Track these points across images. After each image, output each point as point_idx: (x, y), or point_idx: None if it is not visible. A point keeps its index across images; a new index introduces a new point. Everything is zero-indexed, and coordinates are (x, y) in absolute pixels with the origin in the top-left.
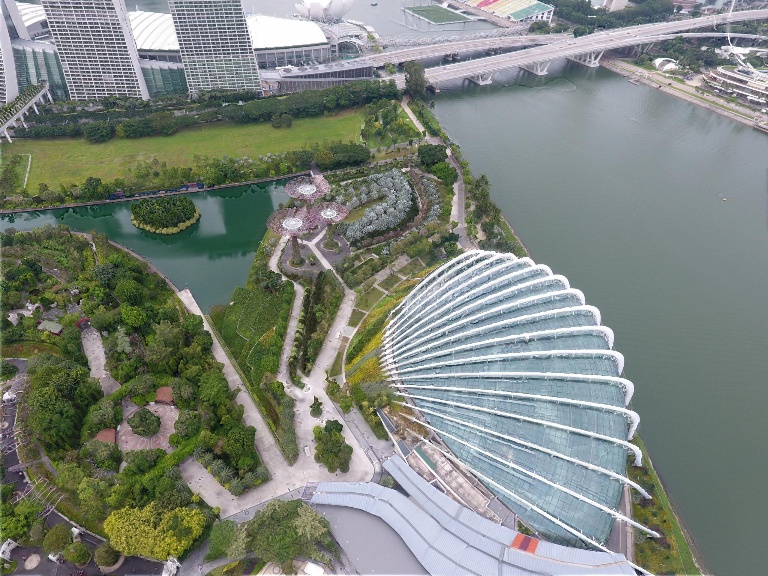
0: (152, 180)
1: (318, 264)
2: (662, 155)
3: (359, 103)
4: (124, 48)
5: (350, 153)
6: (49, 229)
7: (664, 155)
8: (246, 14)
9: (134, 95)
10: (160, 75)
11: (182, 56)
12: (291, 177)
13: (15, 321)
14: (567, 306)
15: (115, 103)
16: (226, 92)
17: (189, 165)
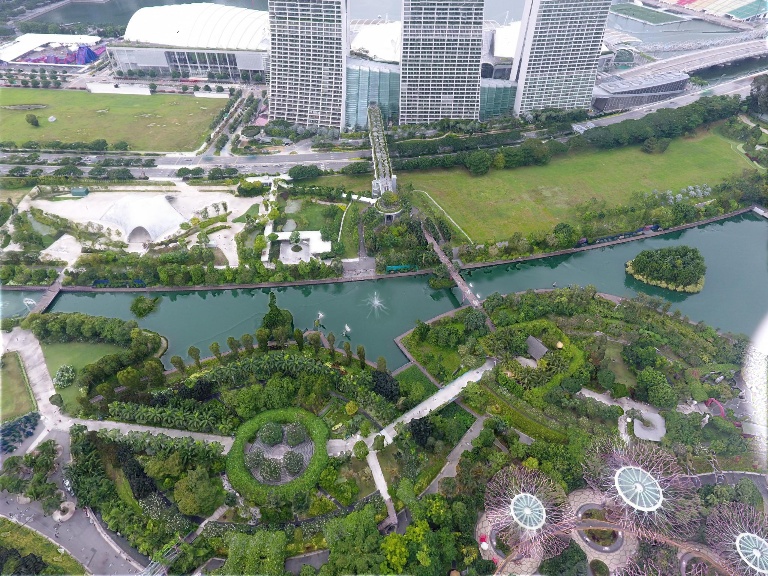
0: (617, 224)
1: None
2: None
3: (708, 122)
4: (476, 66)
5: None
6: (579, 291)
7: None
8: (488, 20)
9: (470, 117)
10: (494, 94)
11: (526, 73)
12: (736, 215)
13: None
14: None
15: (451, 127)
16: (561, 112)
17: (612, 202)
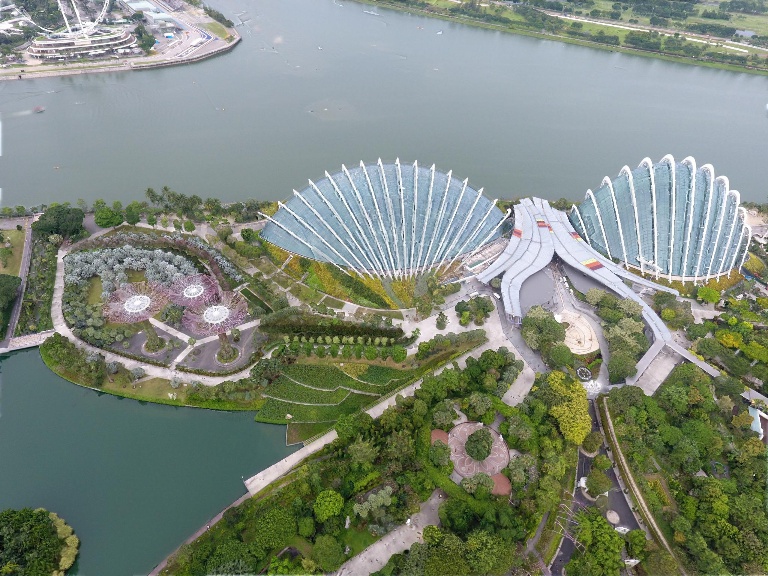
0: None
1: (238, 335)
2: (148, 111)
3: None
4: None
5: None
6: None
7: (148, 110)
8: None
9: None
10: None
11: None
12: None
13: None
14: (374, 169)
15: None
16: None
17: None
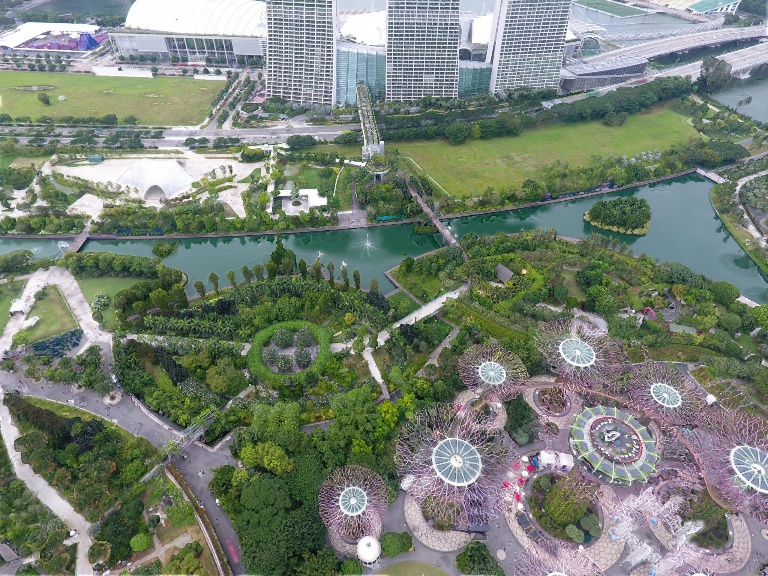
0: (577, 181)
1: None
2: None
3: (663, 100)
4: (454, 48)
5: (734, 150)
6: (542, 232)
7: None
8: (466, 11)
9: (449, 95)
10: (471, 75)
11: (500, 55)
12: (682, 175)
13: (640, 325)
14: None
15: (433, 104)
16: (532, 91)
17: (574, 165)
